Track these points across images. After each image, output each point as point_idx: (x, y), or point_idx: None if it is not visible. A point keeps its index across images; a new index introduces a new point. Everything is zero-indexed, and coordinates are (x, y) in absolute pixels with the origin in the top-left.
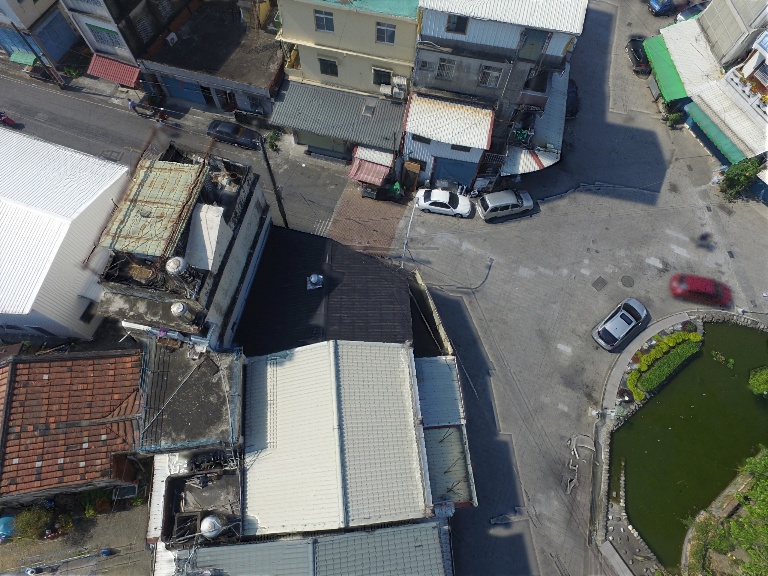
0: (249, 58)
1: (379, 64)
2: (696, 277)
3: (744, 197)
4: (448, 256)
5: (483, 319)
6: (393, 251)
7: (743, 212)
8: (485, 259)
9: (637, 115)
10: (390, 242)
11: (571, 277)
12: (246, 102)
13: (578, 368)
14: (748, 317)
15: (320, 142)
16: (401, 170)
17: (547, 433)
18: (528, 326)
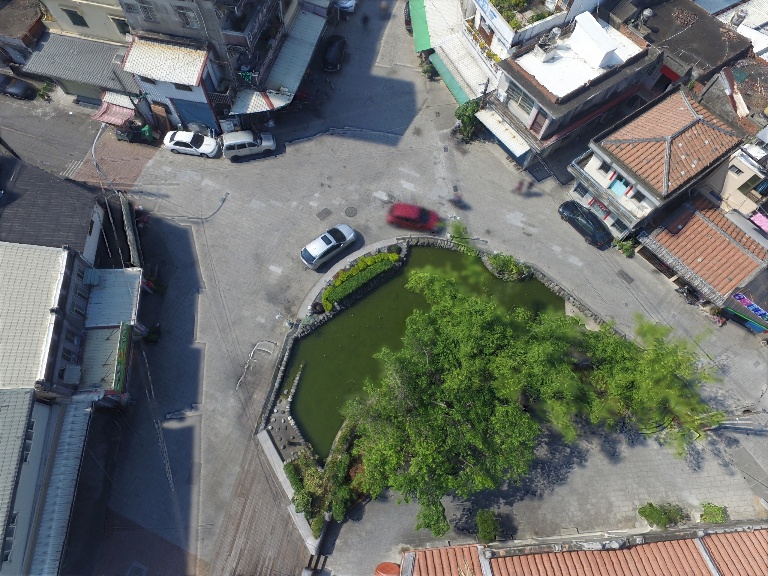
0: (16, 13)
1: (113, 12)
2: (417, 208)
3: (481, 139)
4: (187, 191)
5: (205, 245)
6: (136, 187)
7: (477, 152)
8: (221, 193)
9: (400, 68)
10: (135, 179)
11: (298, 208)
12: (18, 55)
13: (284, 286)
14: (457, 242)
15: (83, 91)
16: (151, 114)
17: (240, 341)
18: (246, 250)
